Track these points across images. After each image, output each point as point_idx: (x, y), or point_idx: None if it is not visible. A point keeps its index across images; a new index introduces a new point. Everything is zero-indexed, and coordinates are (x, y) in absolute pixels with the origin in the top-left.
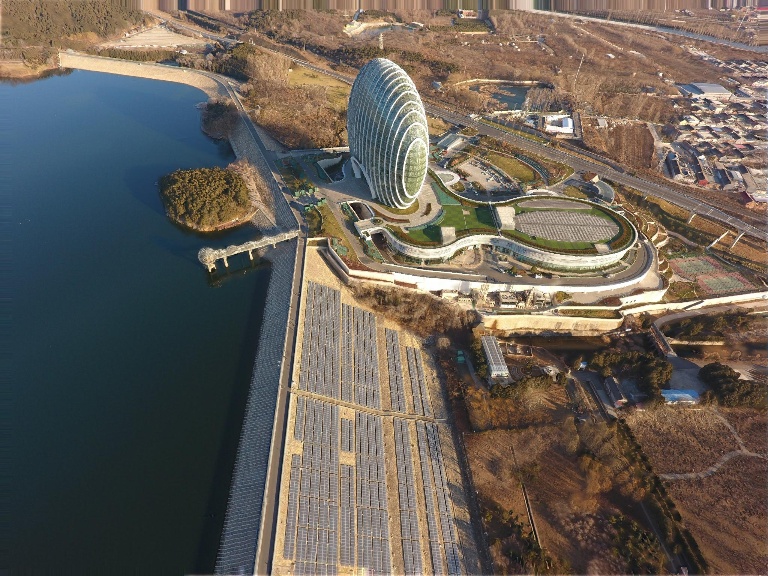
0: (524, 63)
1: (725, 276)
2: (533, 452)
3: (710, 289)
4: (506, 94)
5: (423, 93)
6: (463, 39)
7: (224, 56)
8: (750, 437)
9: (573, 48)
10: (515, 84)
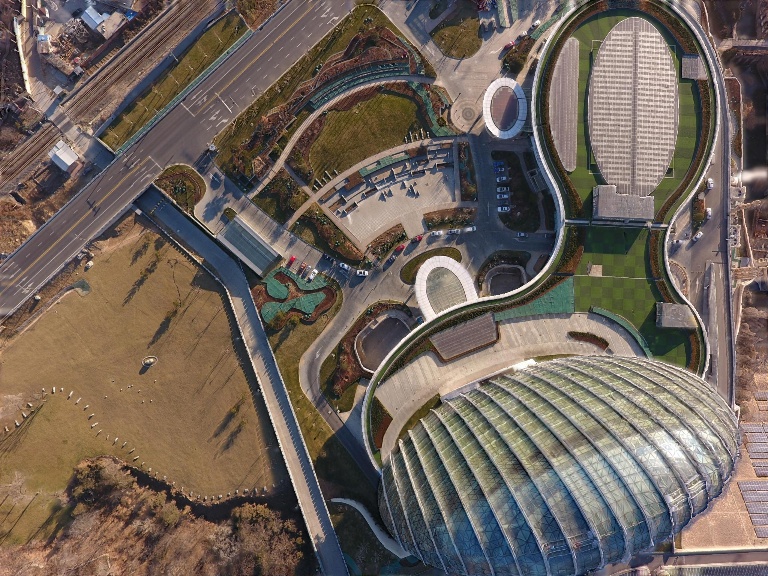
0: None
1: None
2: None
3: None
4: None
5: None
6: None
7: None
8: None
9: None
10: None
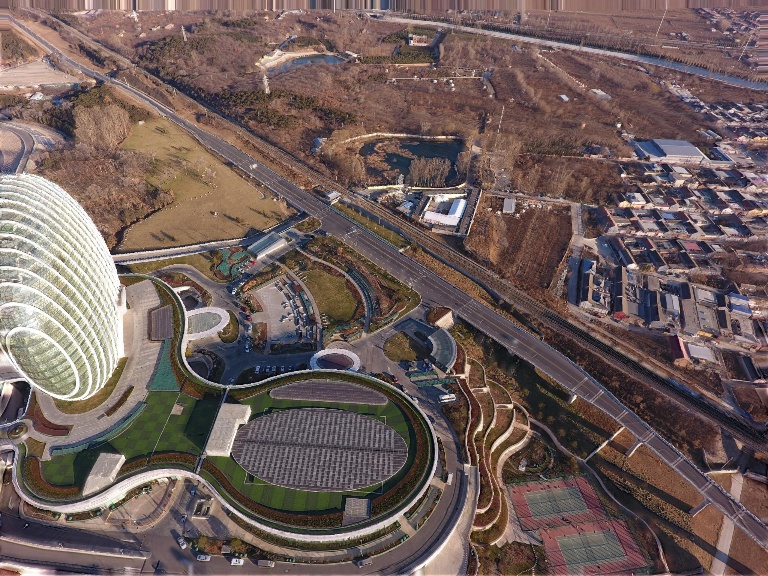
0: (450, 109)
1: (598, 529)
2: None
3: (563, 564)
4: (405, 155)
5: (293, 156)
6: (393, 74)
7: (64, 104)
8: None
9: (520, 87)
10: (425, 140)
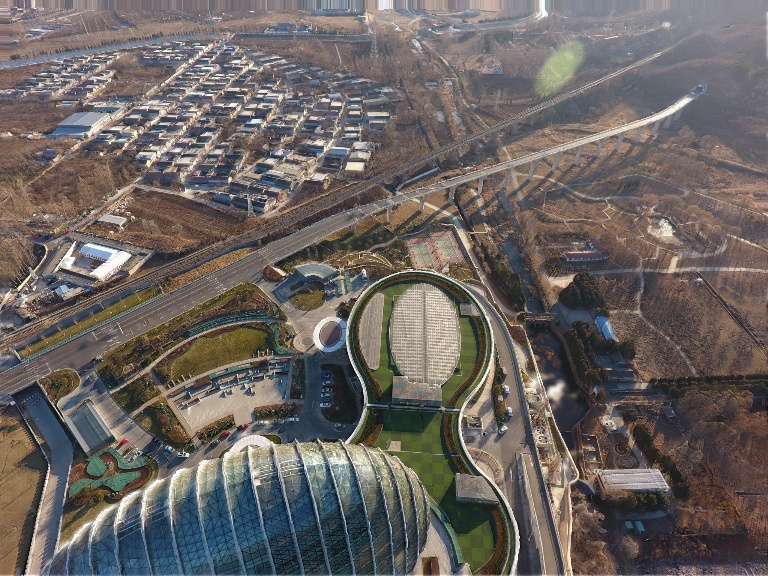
0: None
1: (436, 242)
2: (761, 472)
3: (457, 258)
4: None
5: None
6: None
7: None
8: (622, 304)
9: None
10: None
